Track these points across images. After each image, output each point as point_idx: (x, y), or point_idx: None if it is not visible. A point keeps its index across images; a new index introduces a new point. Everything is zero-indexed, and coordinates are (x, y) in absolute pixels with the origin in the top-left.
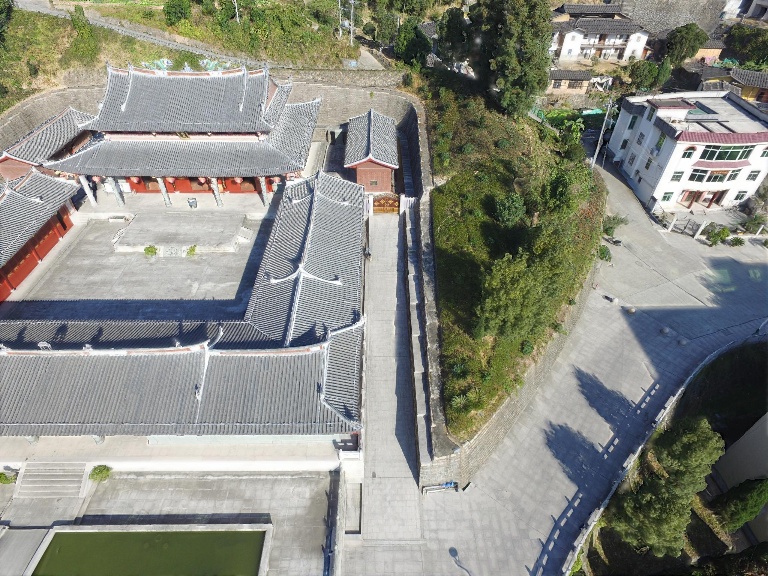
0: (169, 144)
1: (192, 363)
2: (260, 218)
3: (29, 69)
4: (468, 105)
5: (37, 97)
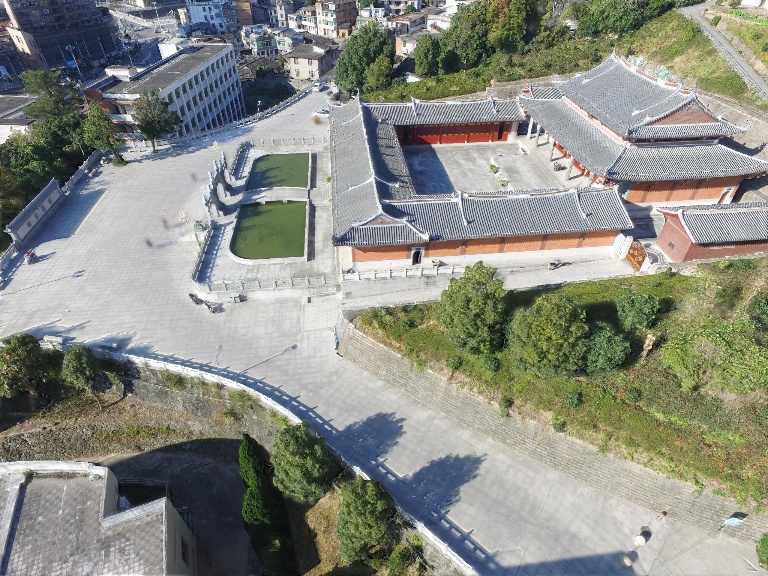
0: (581, 118)
1: None
2: None
3: (627, 52)
4: None
5: None
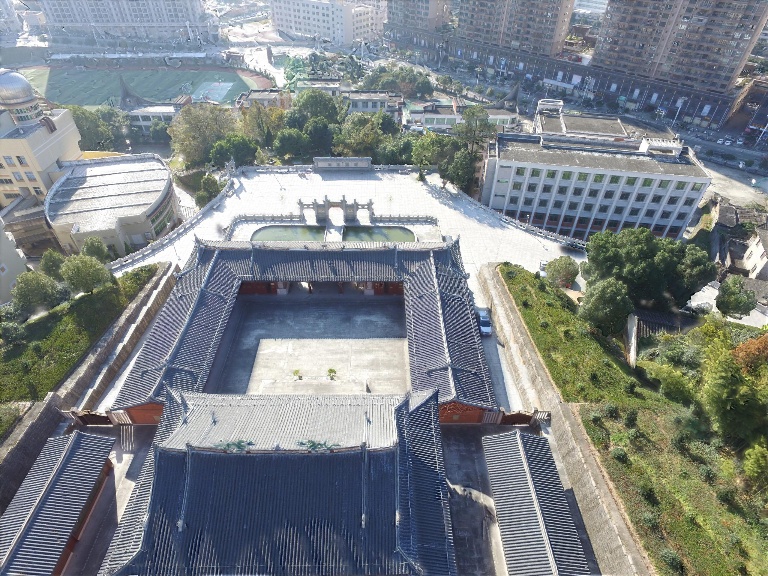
0: None
1: None
2: None
3: None
4: None
5: None
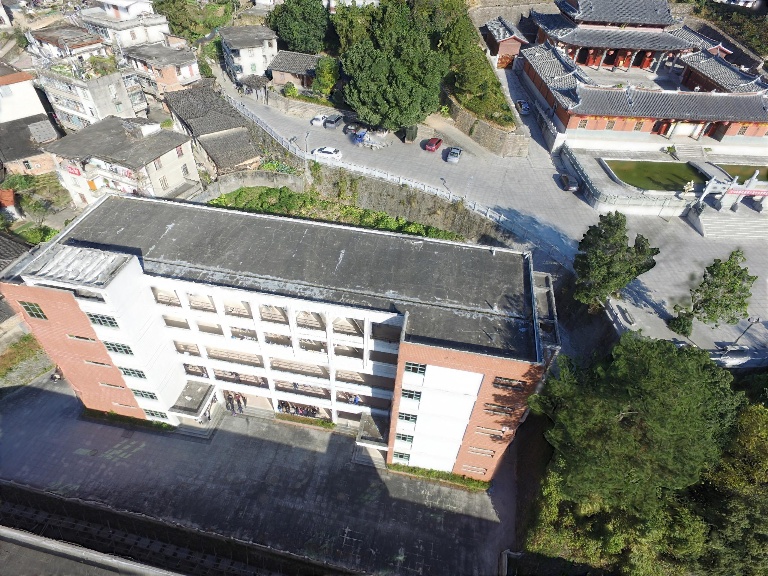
0: (612, 32)
1: (757, 100)
2: (652, 79)
3: None
4: (765, 20)
5: (472, 10)
